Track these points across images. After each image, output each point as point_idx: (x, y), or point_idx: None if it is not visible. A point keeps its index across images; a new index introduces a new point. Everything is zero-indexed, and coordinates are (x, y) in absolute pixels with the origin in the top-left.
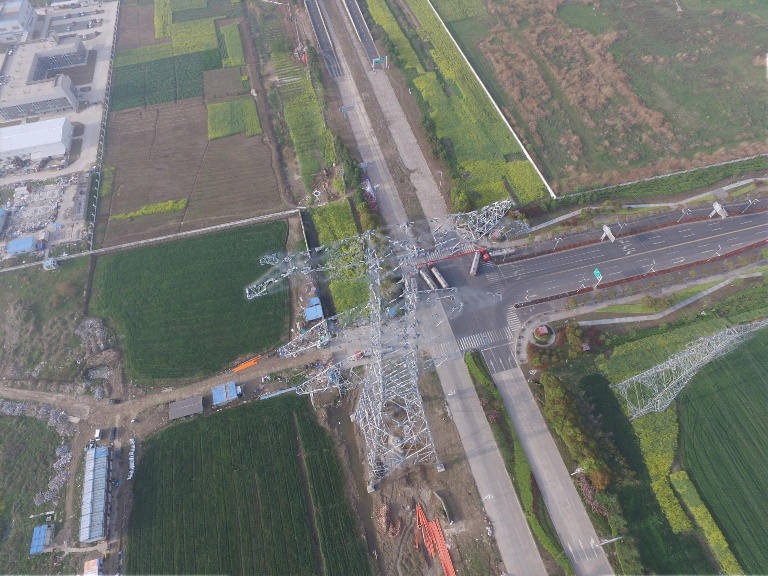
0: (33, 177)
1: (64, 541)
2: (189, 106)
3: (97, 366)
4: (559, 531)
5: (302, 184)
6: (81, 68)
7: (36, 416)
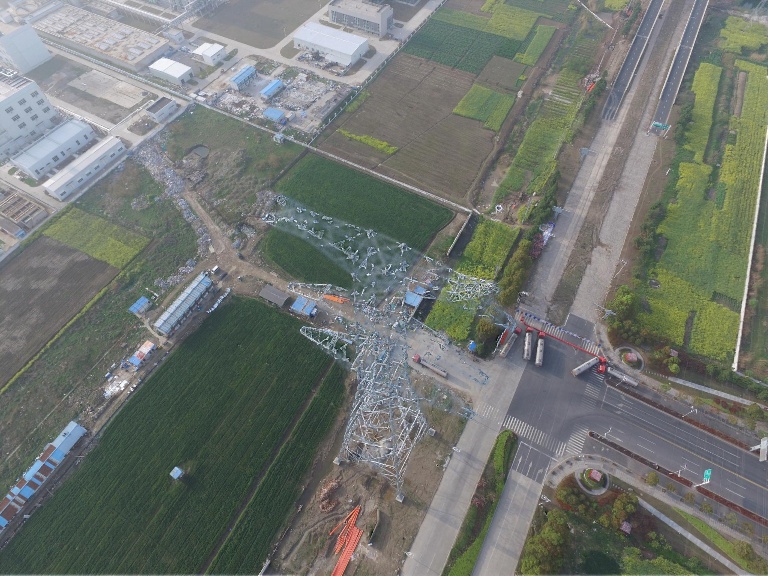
0: (317, 71)
1: (149, 318)
2: (460, 77)
3: (250, 225)
4: None
5: (494, 193)
6: (409, 7)
7: (196, 230)
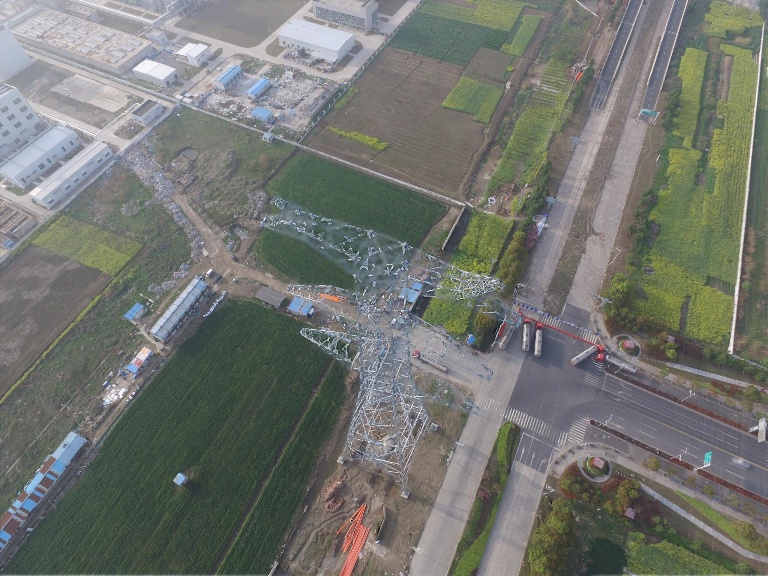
0: (303, 69)
1: (145, 324)
2: (448, 70)
3: (243, 227)
4: None
5: (486, 185)
6: (393, 1)
7: (188, 234)
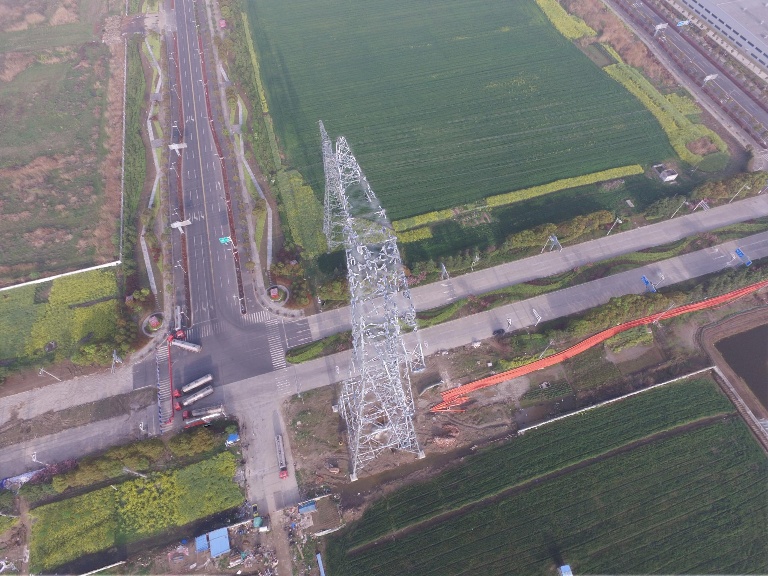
0: None
1: None
2: None
3: None
4: (439, 305)
5: None
6: None
7: None
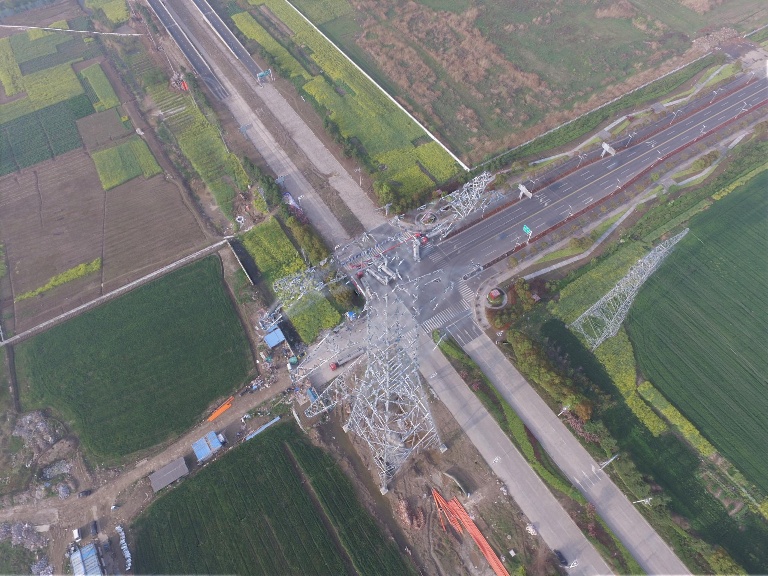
0: None
1: None
2: (70, 160)
3: (51, 463)
4: (563, 469)
5: (221, 213)
6: None
7: None
